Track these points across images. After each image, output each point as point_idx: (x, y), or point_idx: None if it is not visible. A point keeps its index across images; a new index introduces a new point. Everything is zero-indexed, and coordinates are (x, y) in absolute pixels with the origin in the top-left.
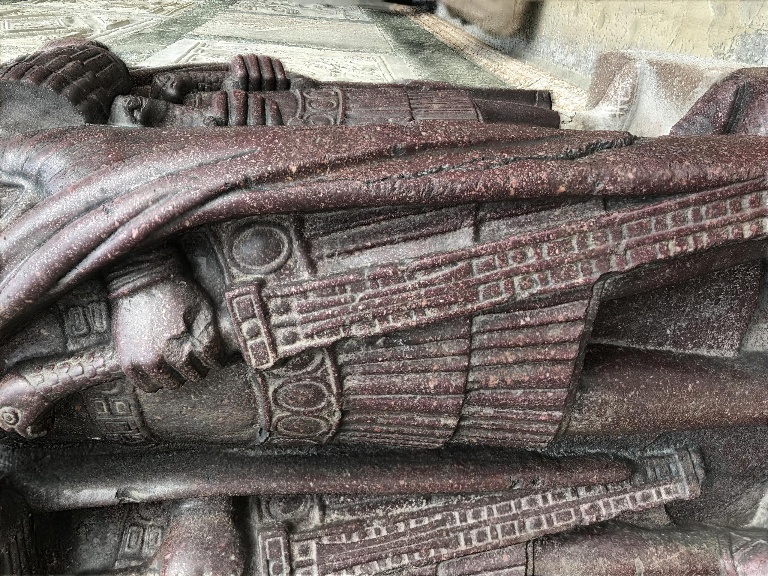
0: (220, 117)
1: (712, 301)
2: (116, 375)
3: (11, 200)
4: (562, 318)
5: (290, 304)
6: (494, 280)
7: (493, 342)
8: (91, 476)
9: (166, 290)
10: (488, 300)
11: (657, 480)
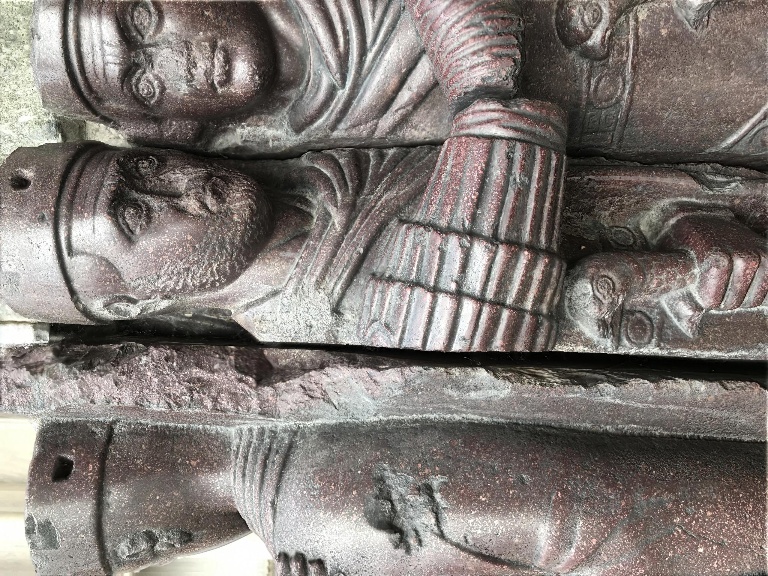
0: (713, 308)
1: None
2: None
3: (539, 575)
4: None
5: None
6: None
7: None
8: None
9: None
10: None
11: None
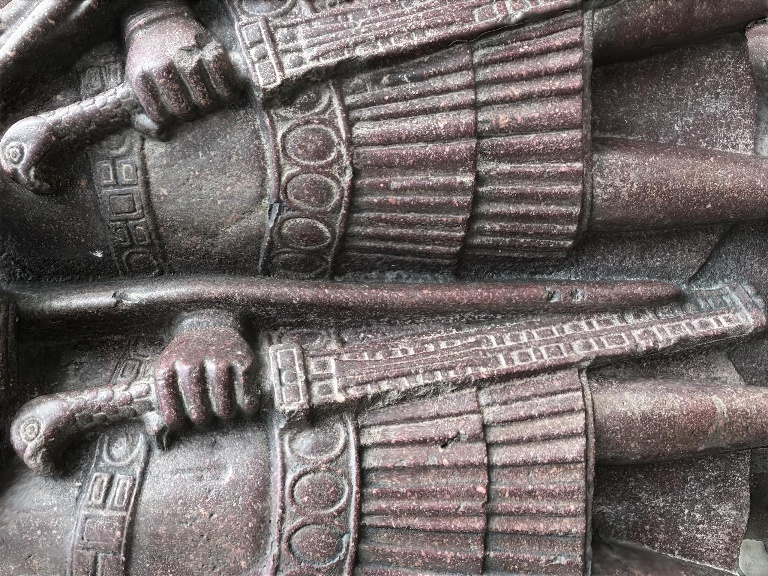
0: None
1: (712, 95)
2: (126, 105)
3: None
4: (559, 42)
5: (296, 34)
6: (486, 3)
7: (496, 74)
8: (88, 286)
9: (180, 22)
10: (484, 21)
11: (712, 310)
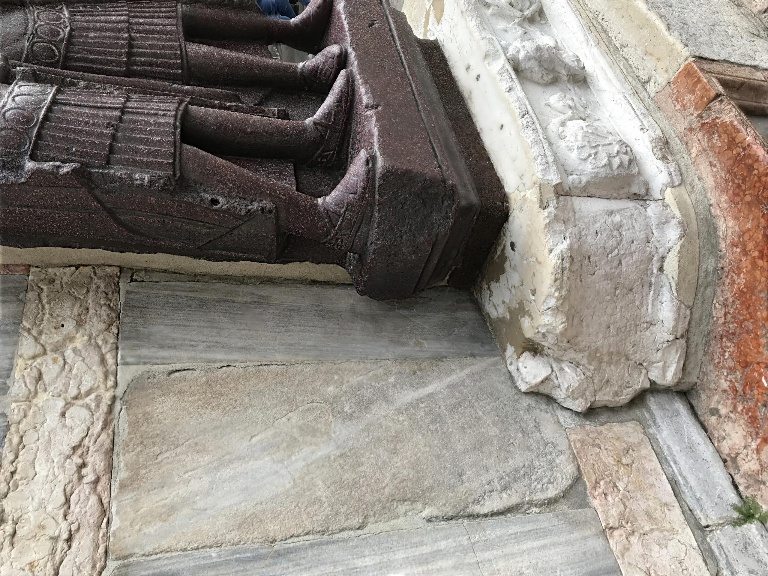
0: None
1: None
2: None
3: None
4: None
5: None
6: None
7: None
8: None
9: None
10: None
11: None
